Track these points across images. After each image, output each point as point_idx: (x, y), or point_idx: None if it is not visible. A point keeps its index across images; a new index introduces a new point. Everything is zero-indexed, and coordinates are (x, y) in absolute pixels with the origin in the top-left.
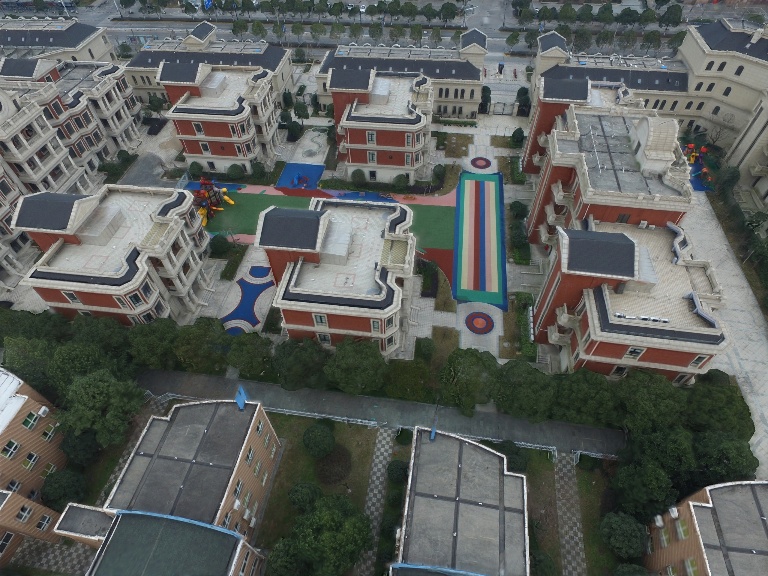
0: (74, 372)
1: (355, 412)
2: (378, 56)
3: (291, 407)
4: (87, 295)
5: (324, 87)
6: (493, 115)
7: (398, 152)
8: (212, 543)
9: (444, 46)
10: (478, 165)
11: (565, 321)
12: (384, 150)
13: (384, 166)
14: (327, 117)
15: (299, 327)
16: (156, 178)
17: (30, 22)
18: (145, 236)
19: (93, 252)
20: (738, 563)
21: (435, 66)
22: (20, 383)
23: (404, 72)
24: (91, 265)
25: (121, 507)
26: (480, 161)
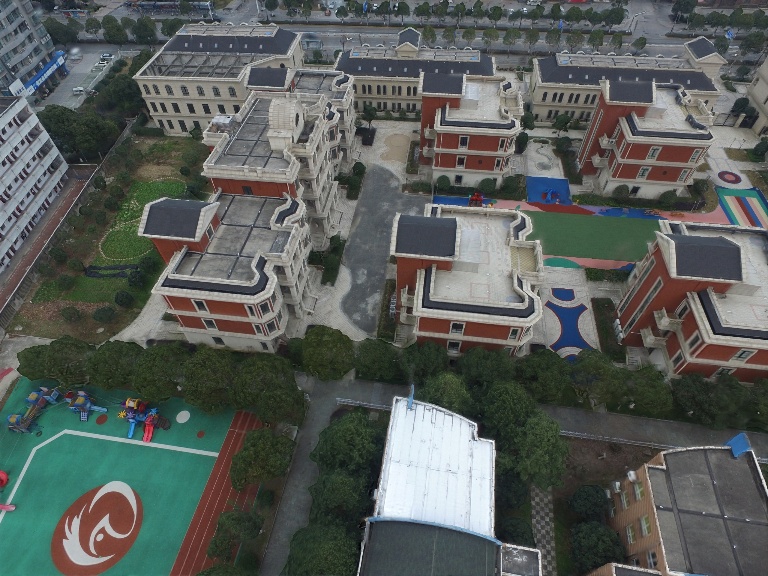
0: (523, 413)
1: (754, 450)
2: (605, 65)
3: (687, 445)
4: (480, 326)
5: (543, 97)
6: (713, 126)
7: (677, 168)
8: None
9: (617, 52)
10: (728, 180)
11: None
12: (662, 166)
13: (653, 182)
14: (540, 127)
15: (709, 361)
16: (397, 192)
17: (231, 28)
18: (511, 262)
19: (469, 279)
20: None
21: (668, 76)
22: (471, 425)
23: (661, 83)
24: (477, 294)
25: (681, 570)
26: (728, 175)
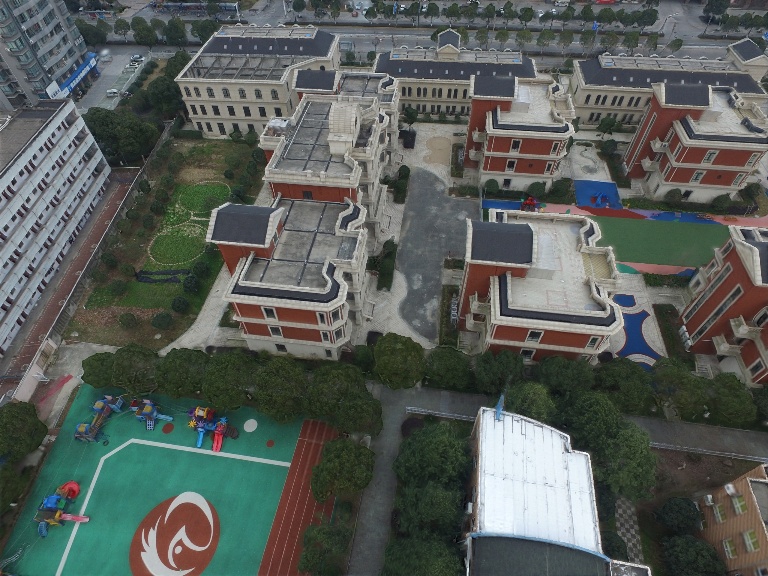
0: None
1: None
2: (649, 67)
3: (767, 455)
4: (559, 334)
5: (586, 99)
6: None
7: (732, 172)
8: None
9: None
10: None
11: None
12: (717, 169)
13: (707, 186)
14: (581, 130)
15: None
16: (444, 195)
17: (270, 29)
18: (584, 268)
19: (544, 286)
20: None
21: (714, 78)
22: (563, 437)
23: (712, 86)
24: (554, 301)
25: None
26: None
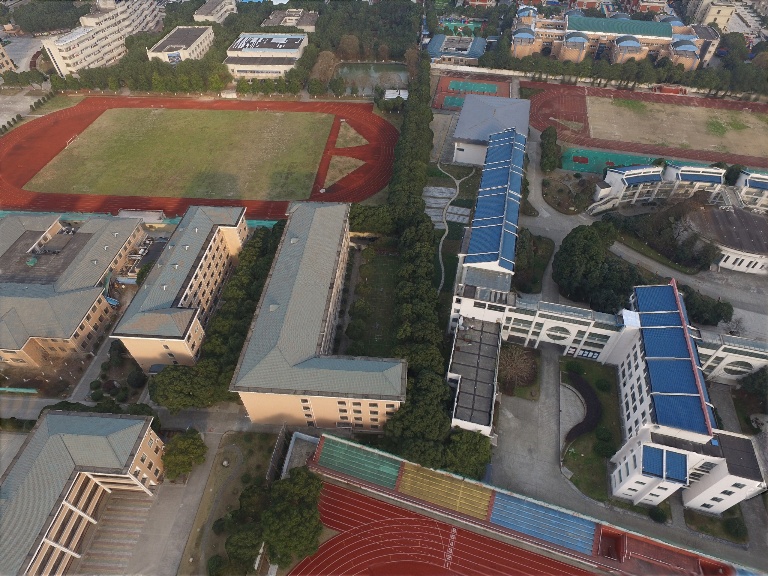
0: None
1: None
2: None
3: None
4: None
5: None
6: None
7: None
8: (582, 14)
9: None
10: None
11: (634, 8)
12: None
13: None
14: None
15: None
16: (510, 2)
17: None
18: None
19: None
20: (661, 18)
21: None
22: (533, 7)
23: None
24: None
25: None
26: (606, 2)
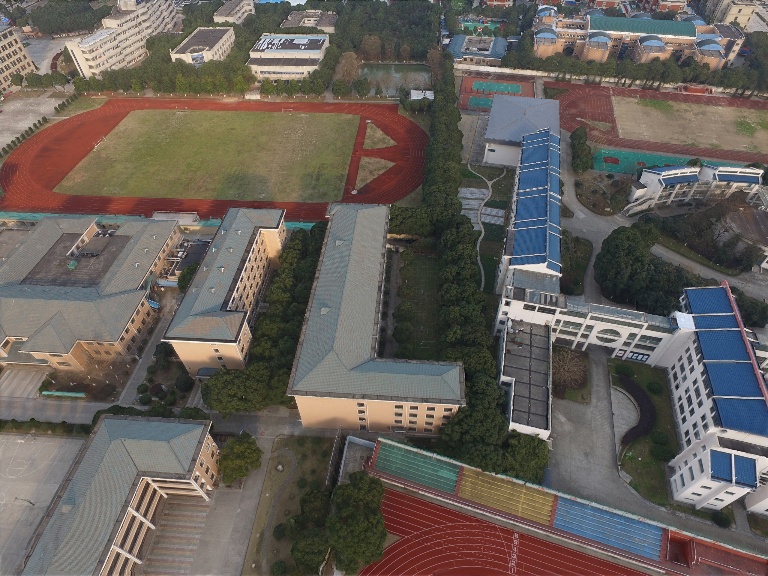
0: None
1: None
2: None
3: None
4: (554, 0)
5: None
6: None
7: None
8: None
9: None
10: (623, 2)
11: (654, 7)
12: None
13: None
14: None
15: (598, 7)
16: (527, 2)
17: None
18: None
19: None
20: None
21: None
22: None
23: None
24: None
25: None
26: None
